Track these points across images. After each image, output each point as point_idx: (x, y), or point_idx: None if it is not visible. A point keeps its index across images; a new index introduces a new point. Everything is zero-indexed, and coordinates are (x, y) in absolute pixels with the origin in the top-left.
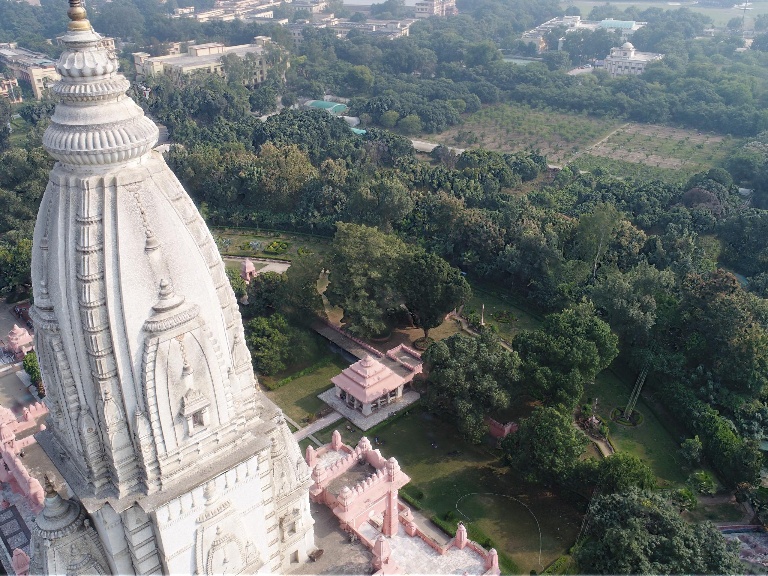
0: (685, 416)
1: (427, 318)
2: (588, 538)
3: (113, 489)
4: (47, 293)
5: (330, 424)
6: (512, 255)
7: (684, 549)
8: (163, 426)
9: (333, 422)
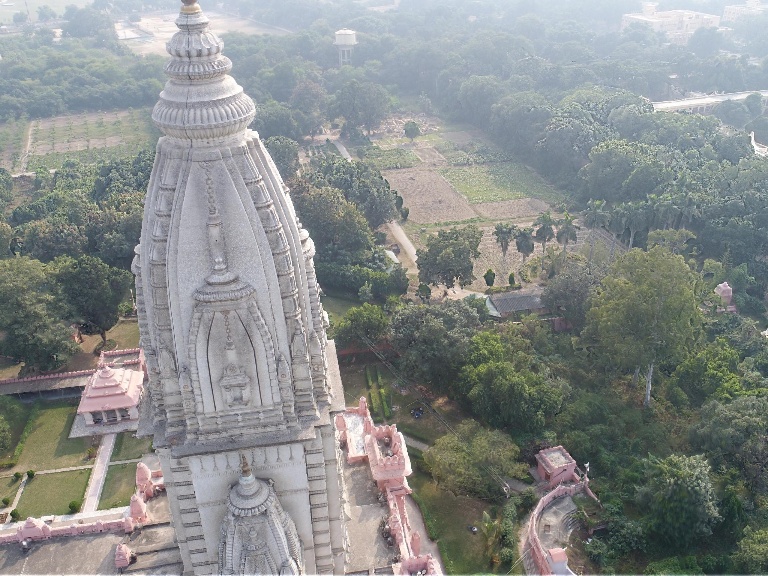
0: (342, 280)
1: (106, 319)
2: (370, 373)
3: (306, 419)
4: (226, 267)
5: (114, 445)
6: (119, 240)
7: (455, 315)
8: (324, 340)
9: (114, 442)
